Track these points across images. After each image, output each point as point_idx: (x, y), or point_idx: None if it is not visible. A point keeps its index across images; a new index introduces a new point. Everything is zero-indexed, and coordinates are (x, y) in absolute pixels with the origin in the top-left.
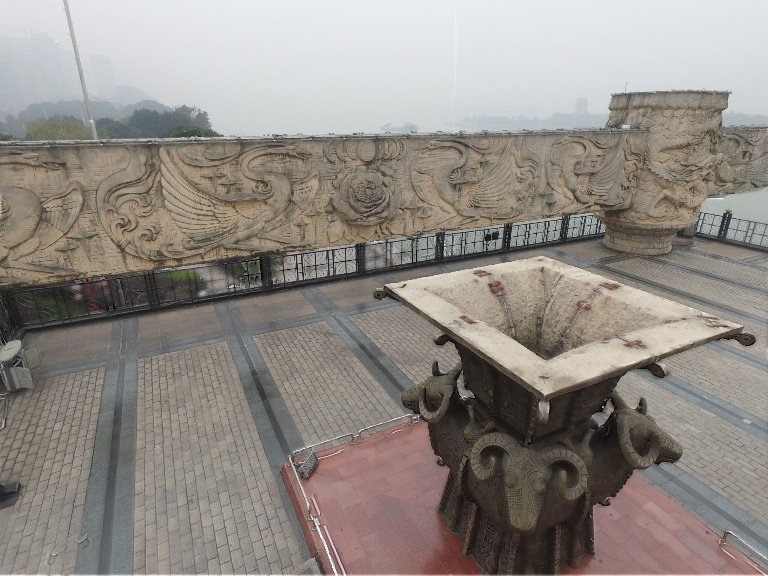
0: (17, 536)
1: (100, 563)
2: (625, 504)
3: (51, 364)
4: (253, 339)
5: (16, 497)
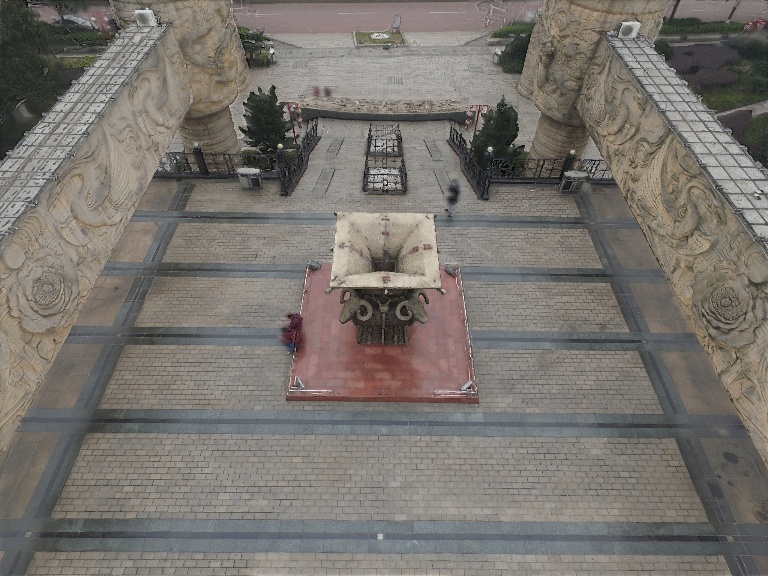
0: (462, 202)
1: (439, 220)
2: (369, 375)
3: (590, 198)
4: (603, 282)
5: (482, 199)
